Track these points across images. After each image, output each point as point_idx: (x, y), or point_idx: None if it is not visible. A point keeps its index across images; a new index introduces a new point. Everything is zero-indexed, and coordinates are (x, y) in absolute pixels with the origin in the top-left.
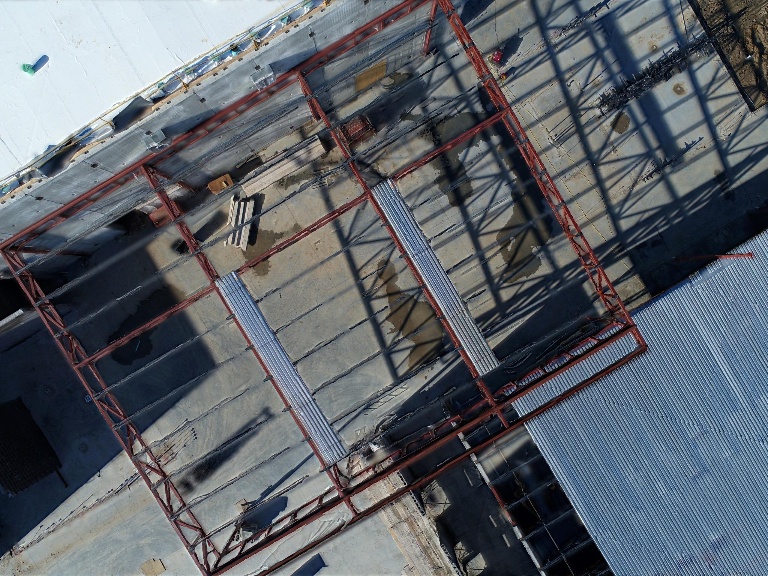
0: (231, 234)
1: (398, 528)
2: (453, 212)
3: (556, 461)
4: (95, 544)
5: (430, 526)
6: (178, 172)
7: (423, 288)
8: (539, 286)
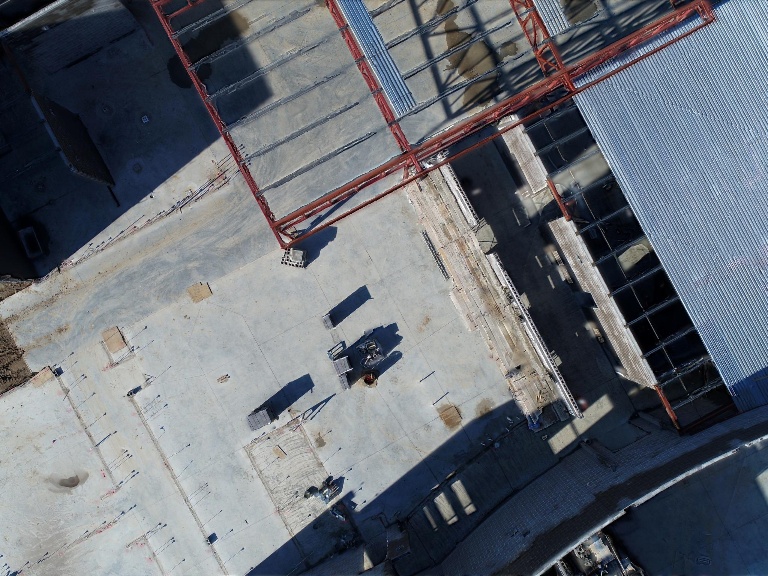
0: None
1: (448, 248)
2: None
3: (614, 157)
4: (143, 265)
5: (480, 248)
6: None
7: None
8: (594, 32)
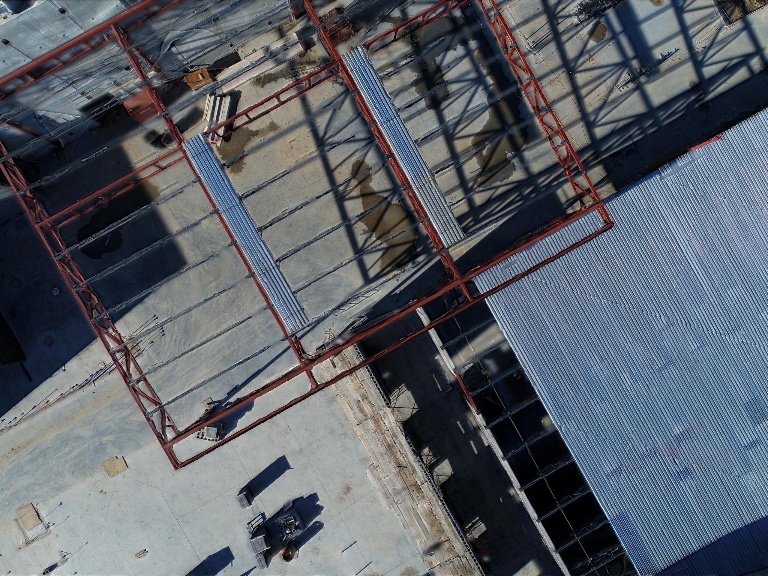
0: (206, 128)
1: (364, 425)
2: (429, 115)
3: (522, 349)
4: (57, 440)
5: (396, 424)
6: (152, 50)
7: (392, 164)
8: (513, 192)
